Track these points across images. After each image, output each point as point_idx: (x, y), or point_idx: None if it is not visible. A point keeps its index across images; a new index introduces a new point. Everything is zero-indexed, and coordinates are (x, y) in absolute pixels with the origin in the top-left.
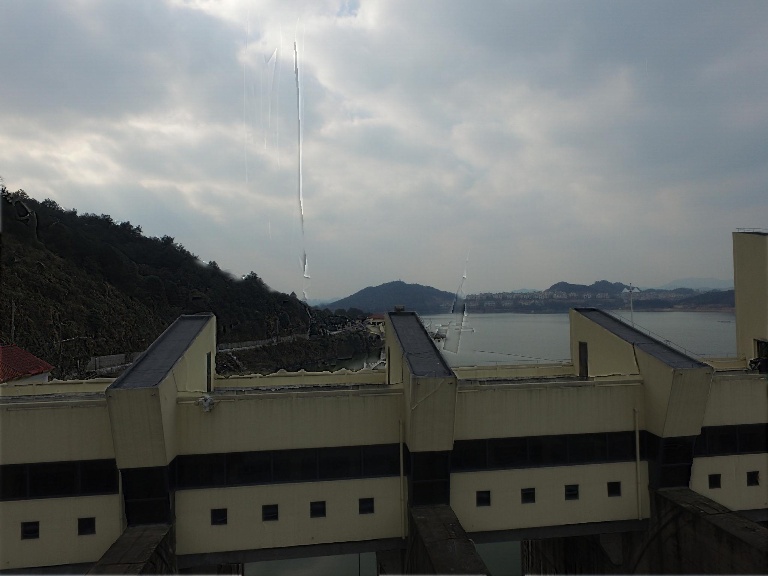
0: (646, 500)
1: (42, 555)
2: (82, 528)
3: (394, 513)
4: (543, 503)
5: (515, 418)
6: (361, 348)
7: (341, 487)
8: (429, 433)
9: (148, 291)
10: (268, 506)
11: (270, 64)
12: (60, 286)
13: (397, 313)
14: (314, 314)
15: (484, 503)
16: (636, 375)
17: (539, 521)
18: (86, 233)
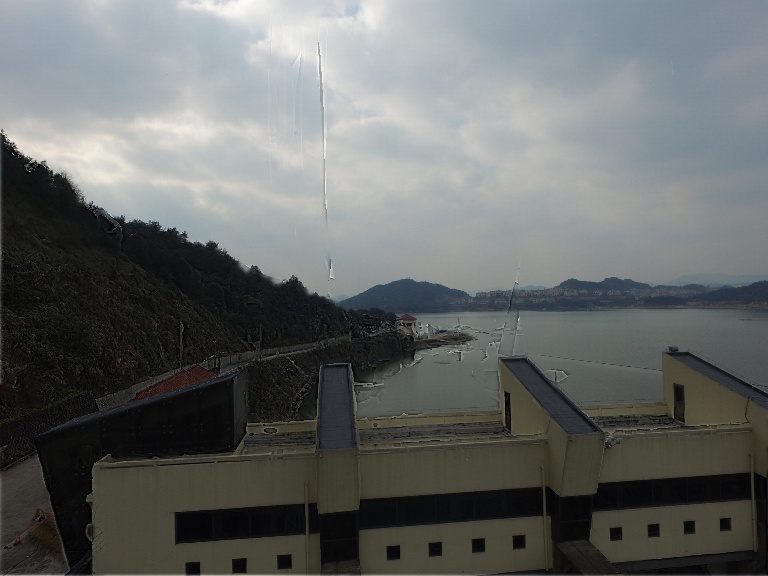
0: None
1: (487, 565)
2: (514, 543)
3: (746, 530)
4: None
5: None
6: (397, 350)
7: (706, 509)
8: None
9: (211, 298)
10: (652, 525)
11: (294, 67)
12: (154, 298)
13: (673, 353)
14: (349, 316)
15: None
16: None
17: None
18: (155, 243)
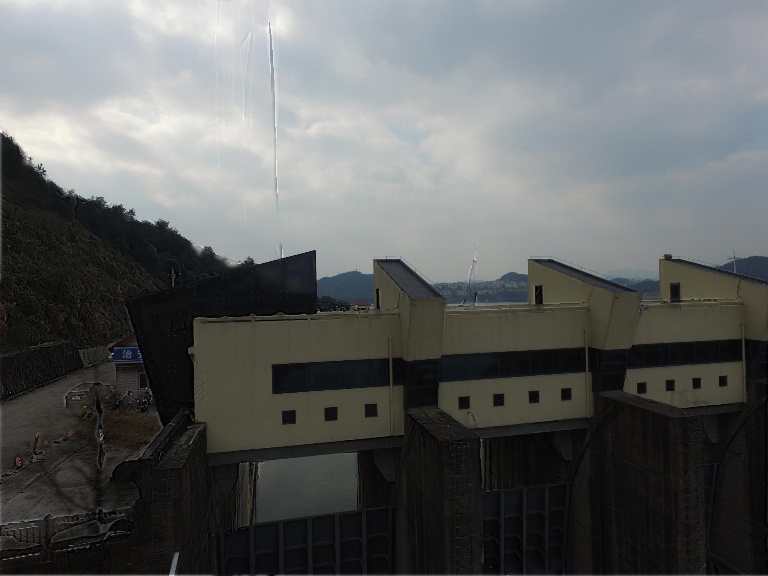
0: None
1: (540, 414)
2: (562, 396)
3: (738, 386)
4: None
5: None
6: None
7: (709, 368)
8: None
9: None
10: (669, 381)
11: (244, 47)
12: (115, 265)
13: (668, 260)
14: None
15: None
16: None
17: None
18: None
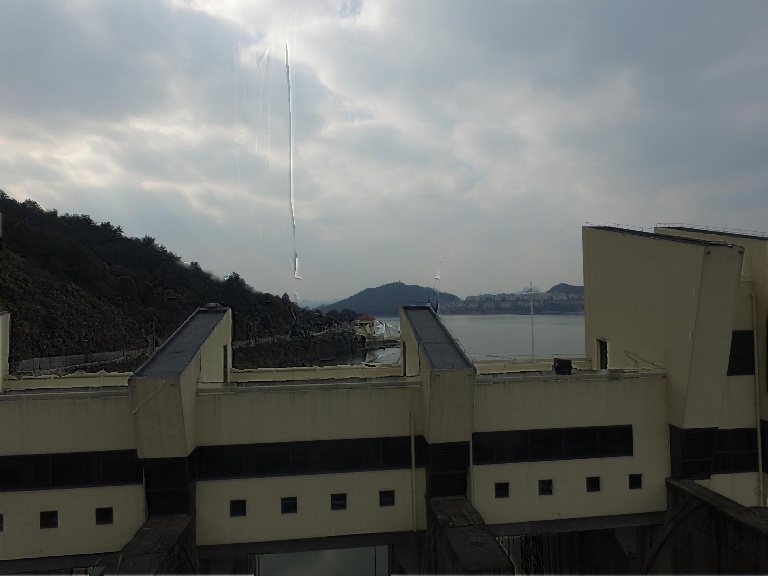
0: (422, 510)
1: None
2: None
3: (136, 524)
4: (306, 513)
5: (276, 422)
6: (345, 349)
7: (76, 496)
8: (157, 438)
9: (119, 291)
10: None
11: (261, 65)
12: (14, 286)
13: (208, 311)
14: (299, 315)
15: (240, 513)
16: (415, 376)
17: (301, 532)
18: (54, 233)
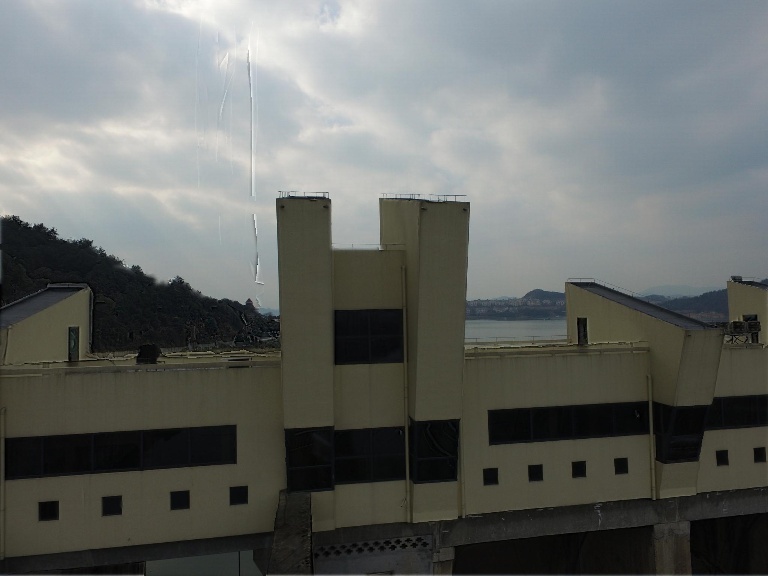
0: None
1: None
2: None
3: None
4: None
5: None
6: None
7: None
8: None
9: None
10: None
11: (222, 67)
12: None
13: None
14: (251, 320)
15: None
16: None
17: None
18: None
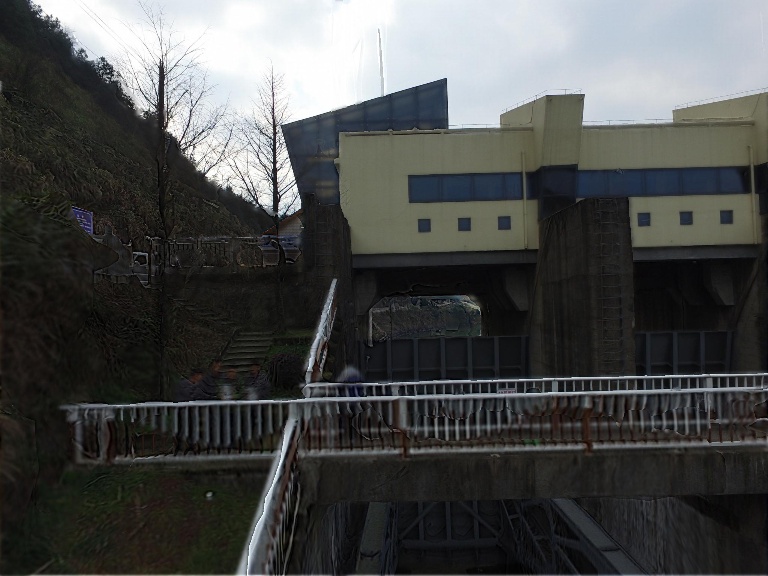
0: None
1: (694, 237)
2: (721, 219)
3: None
4: None
5: None
6: (464, 321)
7: None
8: None
9: None
10: None
11: (355, 54)
12: None
13: None
14: None
15: None
16: None
17: None
18: None
